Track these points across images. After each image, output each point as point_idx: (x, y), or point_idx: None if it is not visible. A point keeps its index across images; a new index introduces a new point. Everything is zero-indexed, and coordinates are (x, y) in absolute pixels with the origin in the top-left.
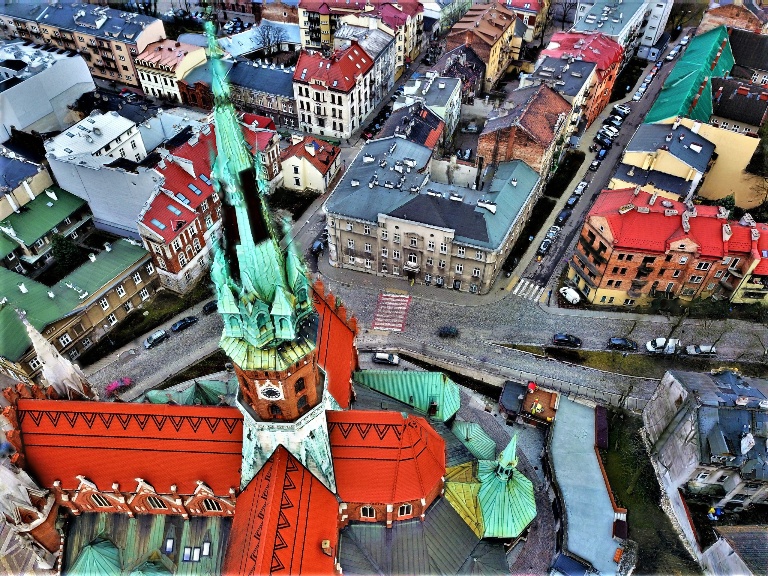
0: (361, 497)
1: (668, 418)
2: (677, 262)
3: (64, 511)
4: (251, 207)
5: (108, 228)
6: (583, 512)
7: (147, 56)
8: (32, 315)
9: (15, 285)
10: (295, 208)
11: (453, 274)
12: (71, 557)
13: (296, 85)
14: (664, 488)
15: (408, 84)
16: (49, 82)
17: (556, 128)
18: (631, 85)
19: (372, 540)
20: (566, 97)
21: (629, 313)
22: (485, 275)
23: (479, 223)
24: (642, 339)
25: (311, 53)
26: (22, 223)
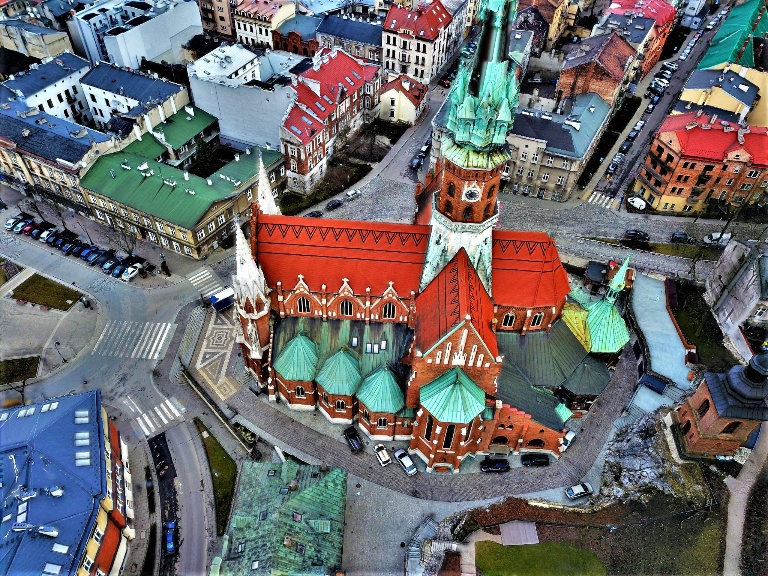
0: (510, 301)
1: (731, 276)
2: (731, 171)
3: (274, 313)
4: (506, 32)
5: (232, 144)
6: (661, 348)
7: (245, 7)
8: (200, 195)
9: (177, 175)
10: (391, 135)
11: (539, 183)
12: (278, 349)
13: (385, 34)
14: (725, 332)
15: None
16: (171, 22)
17: (626, 67)
18: (677, 47)
19: (510, 344)
20: (632, 44)
21: (687, 217)
22: (568, 183)
23: (566, 137)
24: (699, 236)
25: (398, 7)
26: (169, 131)
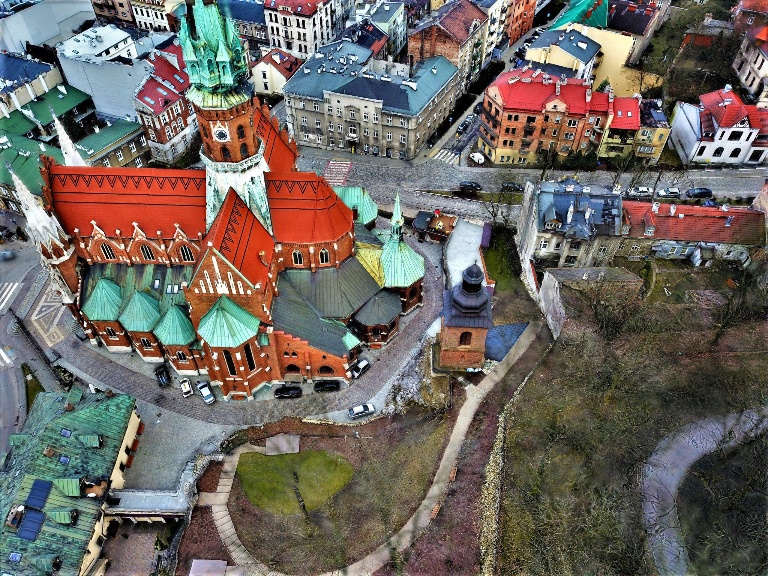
0: (290, 238)
1: (526, 214)
2: (553, 122)
3: (81, 260)
4: None
5: None
6: None
7: None
8: None
9: (36, 147)
10: None
11: (385, 142)
12: (86, 293)
13: (267, 12)
14: (524, 267)
15: (360, 8)
16: (57, 7)
17: (471, 30)
18: (553, 14)
19: (301, 280)
20: (483, 9)
21: (522, 169)
22: (409, 141)
23: (403, 97)
24: None
25: None
26: (39, 109)
